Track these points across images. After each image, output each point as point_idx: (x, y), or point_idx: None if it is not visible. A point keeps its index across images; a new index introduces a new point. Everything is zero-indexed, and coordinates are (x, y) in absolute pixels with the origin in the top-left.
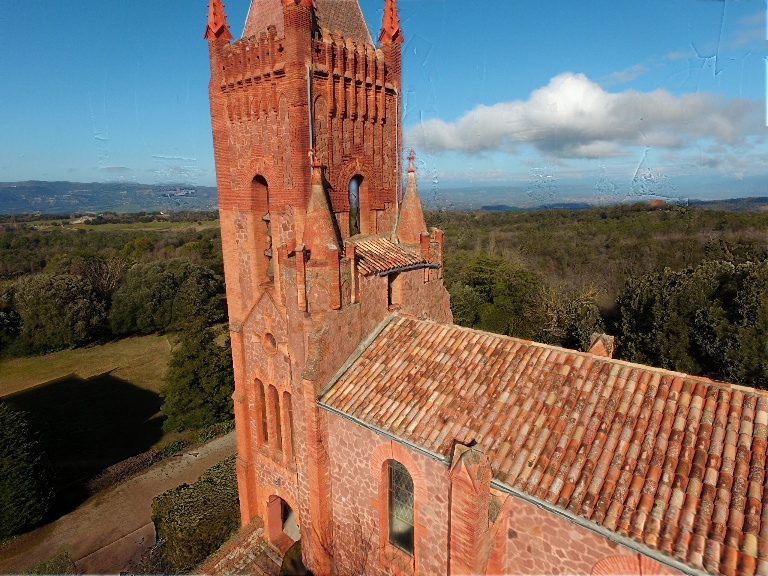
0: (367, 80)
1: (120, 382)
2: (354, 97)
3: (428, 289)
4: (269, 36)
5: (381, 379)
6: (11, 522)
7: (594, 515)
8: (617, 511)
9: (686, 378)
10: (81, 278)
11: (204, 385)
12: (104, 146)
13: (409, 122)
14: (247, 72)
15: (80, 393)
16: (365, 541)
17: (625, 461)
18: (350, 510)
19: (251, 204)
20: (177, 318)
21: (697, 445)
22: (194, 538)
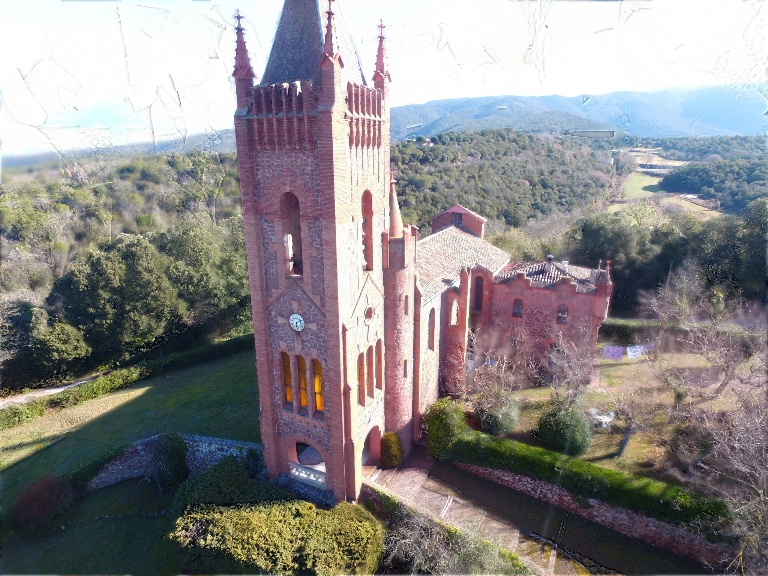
0: None
1: None
2: None
3: None
4: None
5: None
6: None
7: None
8: None
9: (420, 242)
10: None
11: None
12: None
13: None
14: None
15: None
16: None
17: None
18: None
19: None
20: None
21: None
22: None
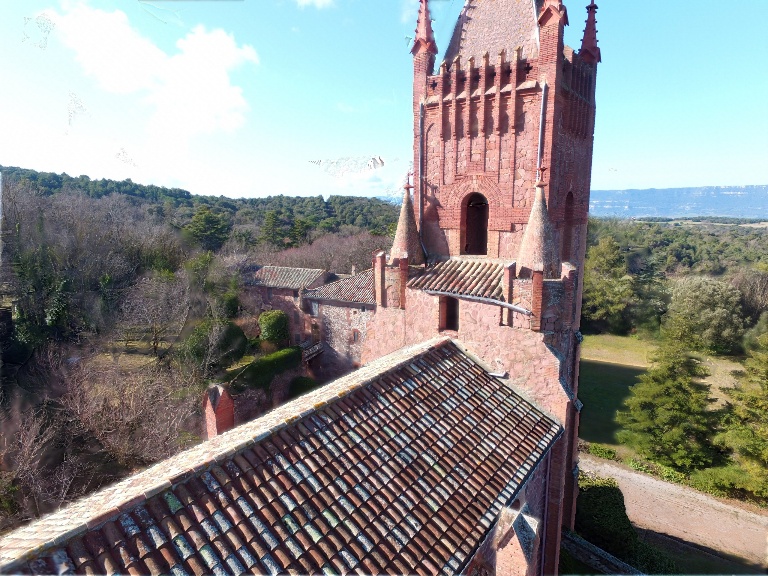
0: (489, 91)
1: None
2: (468, 115)
3: (509, 335)
4: None
5: None
6: None
7: None
8: None
9: None
10: (732, 288)
11: (660, 416)
12: None
13: None
14: None
15: None
16: None
17: None
18: None
19: None
20: (665, 337)
21: None
22: None
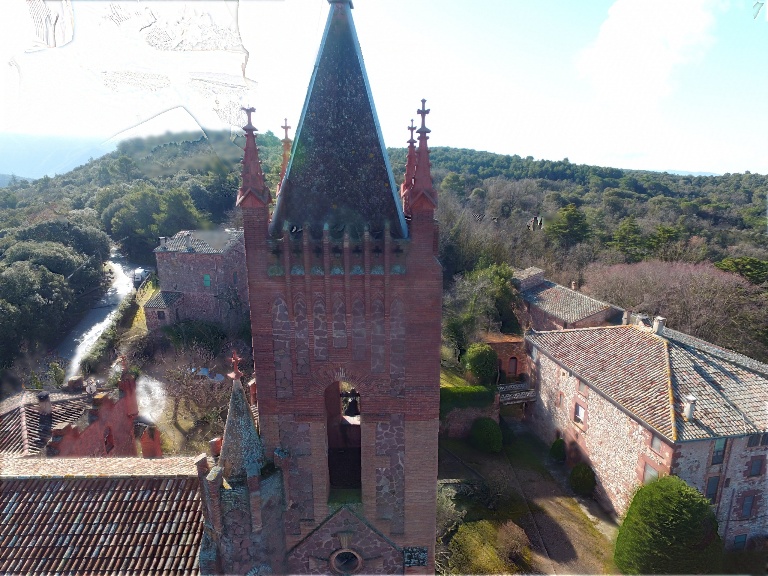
0: None
1: None
2: None
3: None
4: None
5: None
6: None
7: None
8: None
9: None
10: None
11: None
12: None
13: None
14: None
15: None
16: None
17: None
18: None
19: None
20: None
21: None
22: None
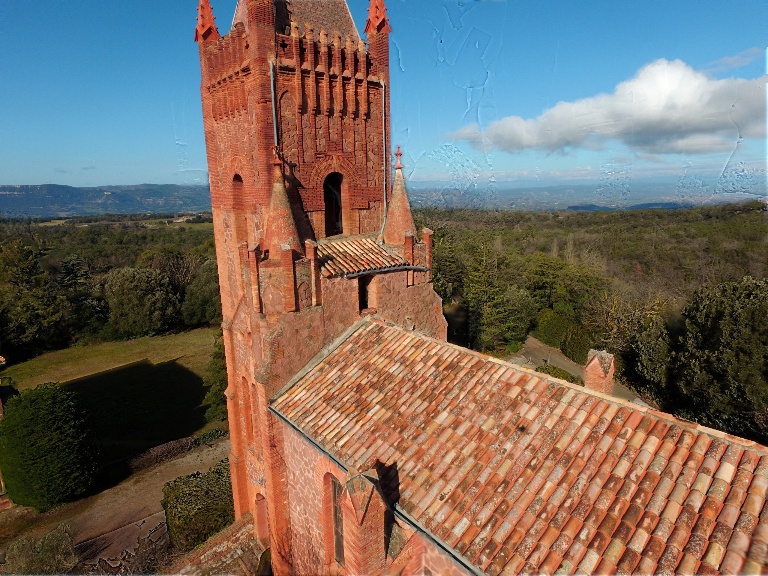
0: (345, 73)
1: (183, 369)
2: (328, 92)
3: (413, 293)
4: (236, 34)
5: (332, 387)
6: (57, 491)
7: (489, 568)
8: (516, 567)
9: (646, 413)
10: (159, 272)
11: None
12: (183, 151)
13: (470, 119)
14: (224, 72)
15: (148, 377)
16: (315, 554)
17: (544, 507)
18: (303, 520)
19: (233, 203)
20: None
21: (634, 498)
22: (189, 527)
